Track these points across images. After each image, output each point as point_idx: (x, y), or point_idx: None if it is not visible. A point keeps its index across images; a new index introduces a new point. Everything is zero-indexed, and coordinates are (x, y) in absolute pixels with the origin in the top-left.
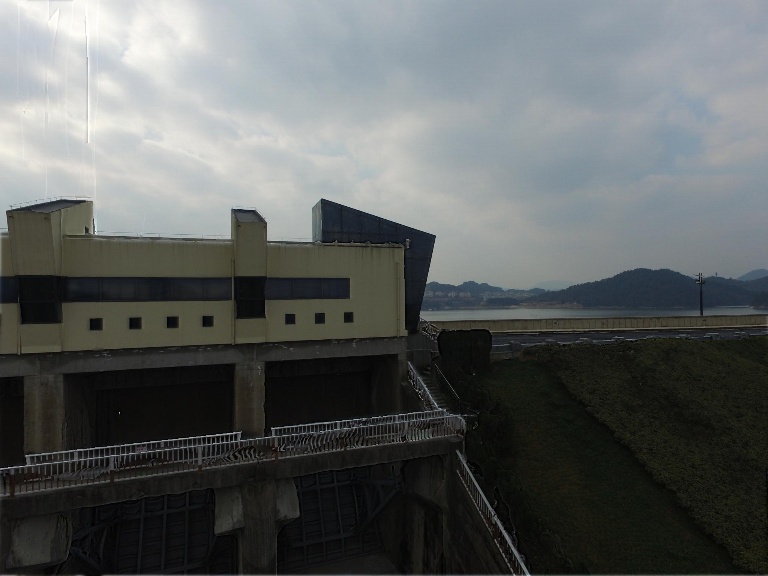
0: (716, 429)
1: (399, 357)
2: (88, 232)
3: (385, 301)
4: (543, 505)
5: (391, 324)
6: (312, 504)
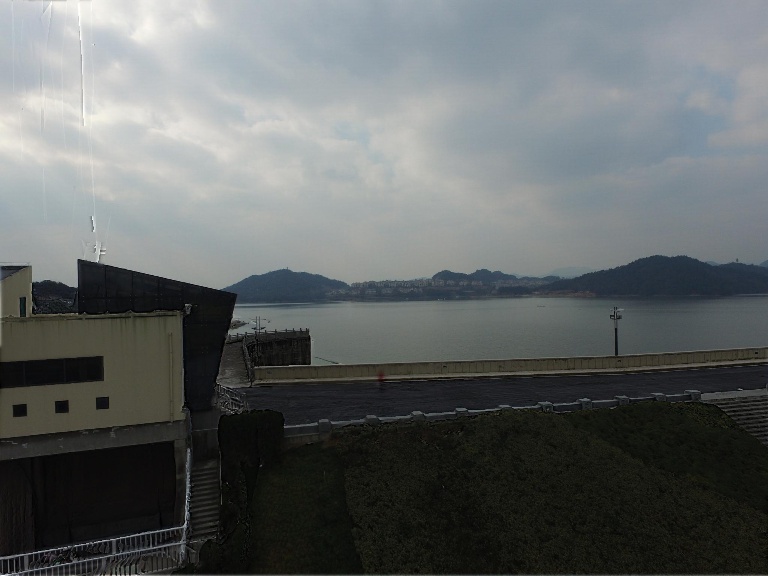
0: (500, 565)
1: (175, 444)
2: None
3: (154, 380)
4: None
5: (162, 407)
6: None
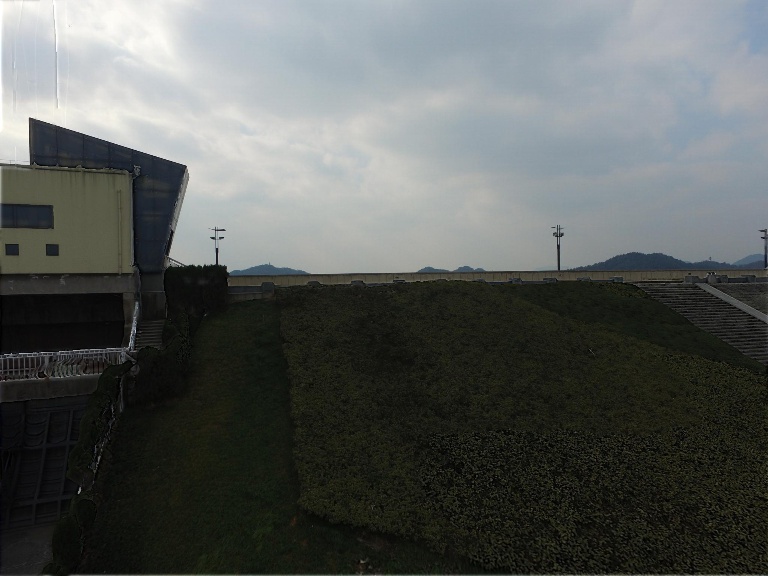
0: (414, 365)
1: (124, 296)
2: None
3: (103, 233)
4: (171, 445)
5: (111, 259)
6: (61, 461)
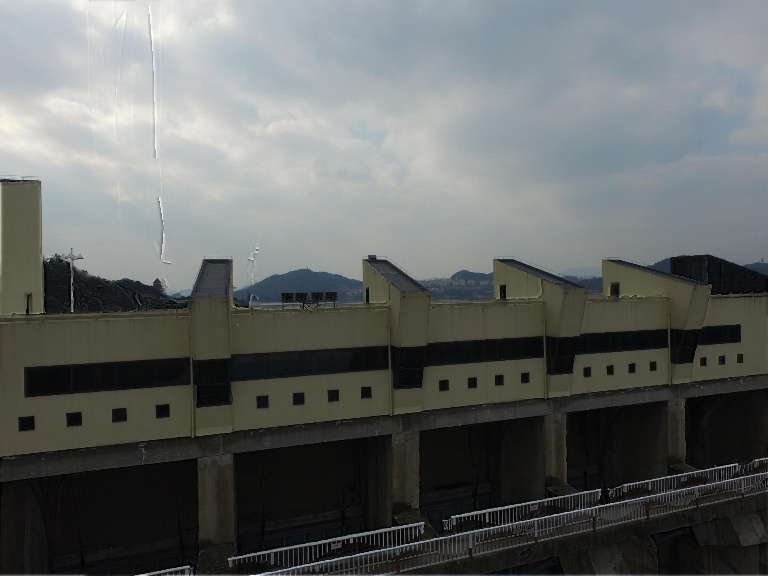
0: None
1: None
2: None
3: (763, 343)
4: None
5: (767, 363)
6: None
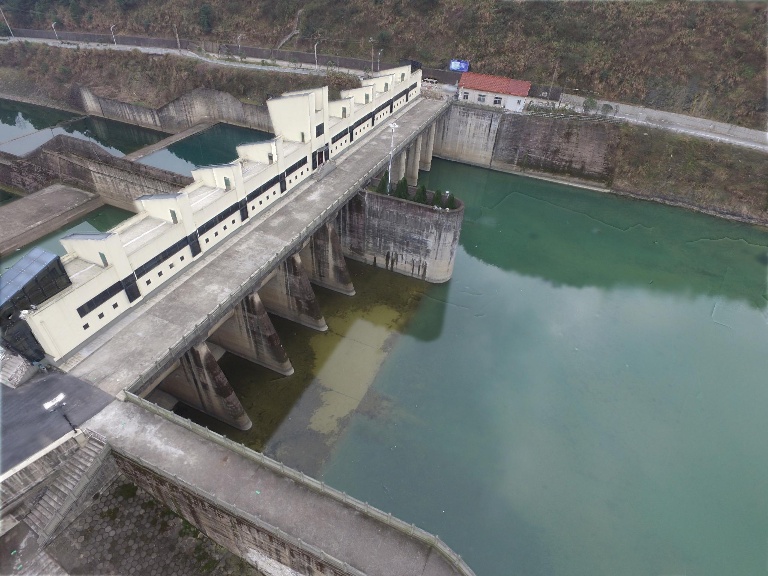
0: None
1: None
2: (175, 212)
3: None
4: None
5: None
6: None
